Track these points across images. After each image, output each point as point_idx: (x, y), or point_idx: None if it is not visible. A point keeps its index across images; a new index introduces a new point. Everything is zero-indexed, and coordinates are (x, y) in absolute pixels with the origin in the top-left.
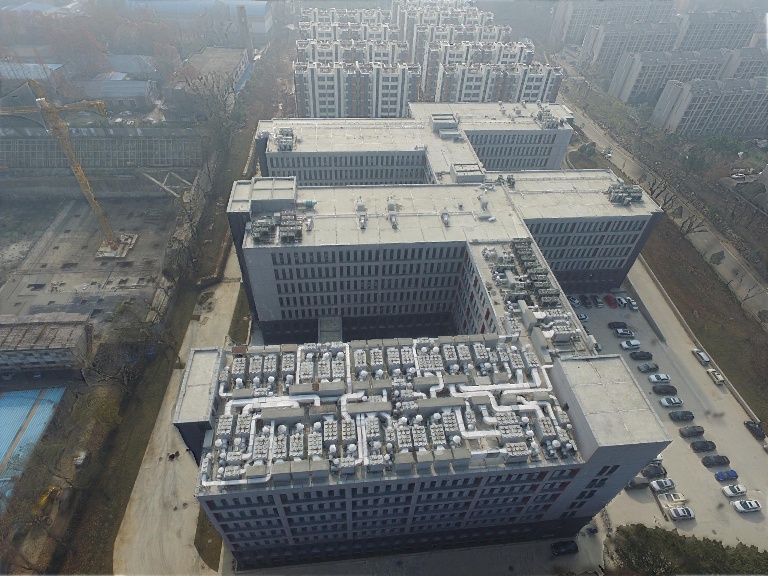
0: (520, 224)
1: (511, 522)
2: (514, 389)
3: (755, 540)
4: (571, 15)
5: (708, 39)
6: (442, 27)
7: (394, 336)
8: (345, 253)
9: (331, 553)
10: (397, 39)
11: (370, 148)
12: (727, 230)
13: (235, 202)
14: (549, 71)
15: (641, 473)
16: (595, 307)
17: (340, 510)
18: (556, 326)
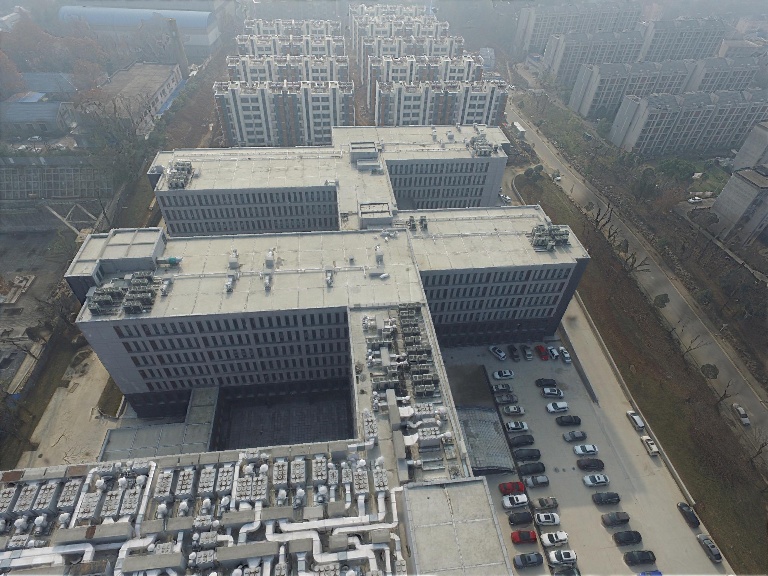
0: (416, 282)
1: None
2: (348, 526)
3: None
4: (534, 23)
5: (675, 48)
6: (390, 39)
7: (291, 401)
8: (205, 323)
9: None
10: (343, 52)
11: (275, 183)
12: (676, 265)
13: (80, 262)
14: (493, 89)
15: None
16: (524, 360)
17: None
18: (423, 427)
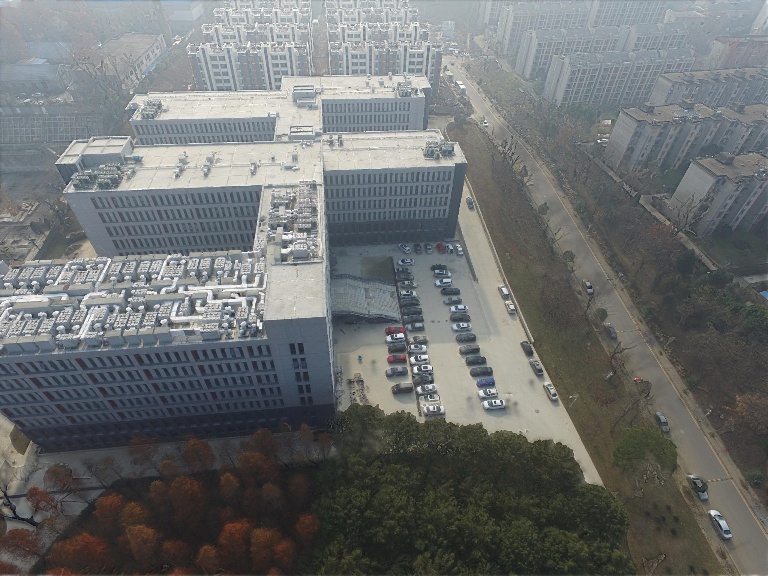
0: (319, 172)
1: (260, 408)
2: (233, 288)
3: (491, 430)
4: None
5: (621, 17)
6: (351, 10)
7: None
8: (158, 197)
9: (120, 439)
10: (309, 23)
11: (228, 116)
12: (566, 186)
13: (67, 156)
14: (428, 47)
15: (412, 381)
16: (425, 253)
17: (84, 385)
18: None
